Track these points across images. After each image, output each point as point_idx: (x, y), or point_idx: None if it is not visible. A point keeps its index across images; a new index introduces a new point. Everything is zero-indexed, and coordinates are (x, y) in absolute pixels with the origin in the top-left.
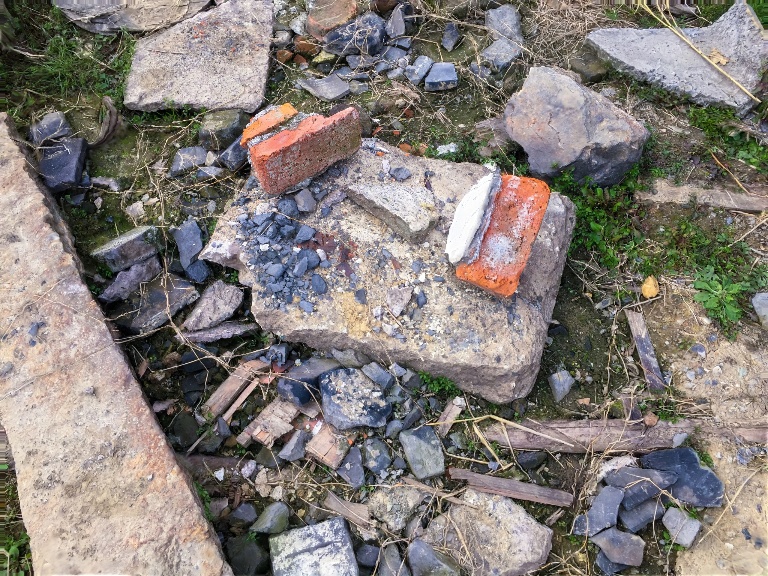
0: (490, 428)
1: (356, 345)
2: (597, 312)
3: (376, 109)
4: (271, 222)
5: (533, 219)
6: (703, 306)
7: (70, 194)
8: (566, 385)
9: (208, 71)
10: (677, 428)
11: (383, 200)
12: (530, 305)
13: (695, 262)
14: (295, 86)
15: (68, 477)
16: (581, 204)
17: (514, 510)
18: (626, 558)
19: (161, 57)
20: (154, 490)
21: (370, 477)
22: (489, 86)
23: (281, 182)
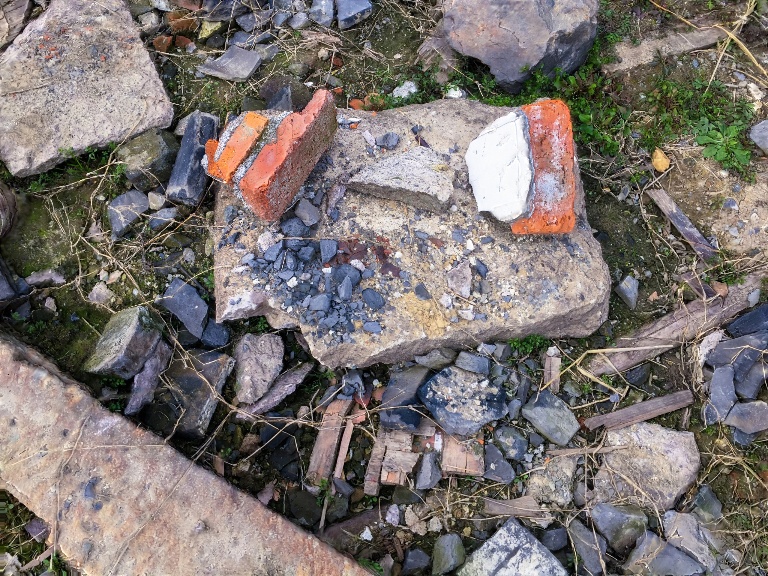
0: (592, 363)
1: (439, 344)
2: (622, 204)
3: (303, 71)
4: (285, 252)
5: (565, 144)
6: (715, 160)
7: (11, 309)
8: (635, 290)
9: (90, 95)
10: (747, 287)
11: (396, 180)
12: (579, 228)
13: (688, 119)
14: (196, 76)
15: None
16: (560, 99)
17: (654, 431)
18: (760, 425)
19: (23, 99)
20: None
21: (517, 466)
22: (401, 0)
23: (280, 205)
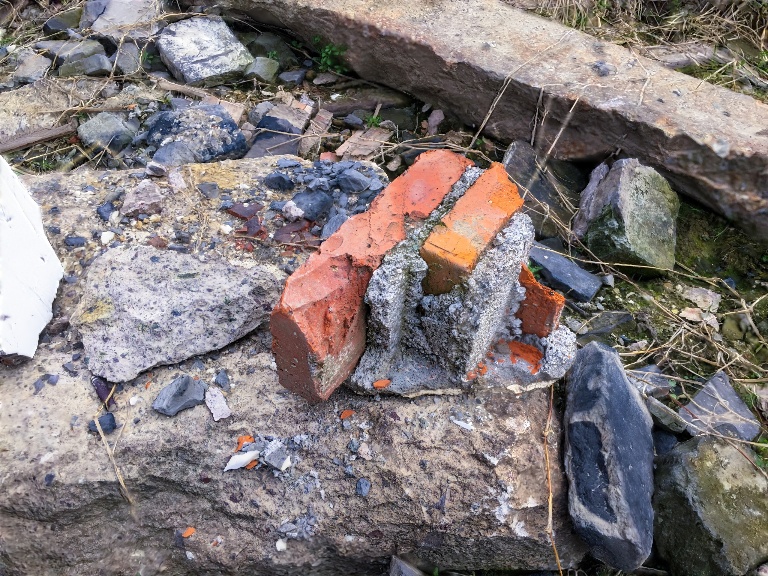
0: None
1: None
2: None
3: None
4: None
5: None
6: None
7: None
8: None
9: None
10: None
11: (189, 269)
12: None
13: None
14: None
15: (451, 4)
16: None
17: None
18: None
19: None
20: (362, 5)
21: (165, 107)
22: None
23: None
